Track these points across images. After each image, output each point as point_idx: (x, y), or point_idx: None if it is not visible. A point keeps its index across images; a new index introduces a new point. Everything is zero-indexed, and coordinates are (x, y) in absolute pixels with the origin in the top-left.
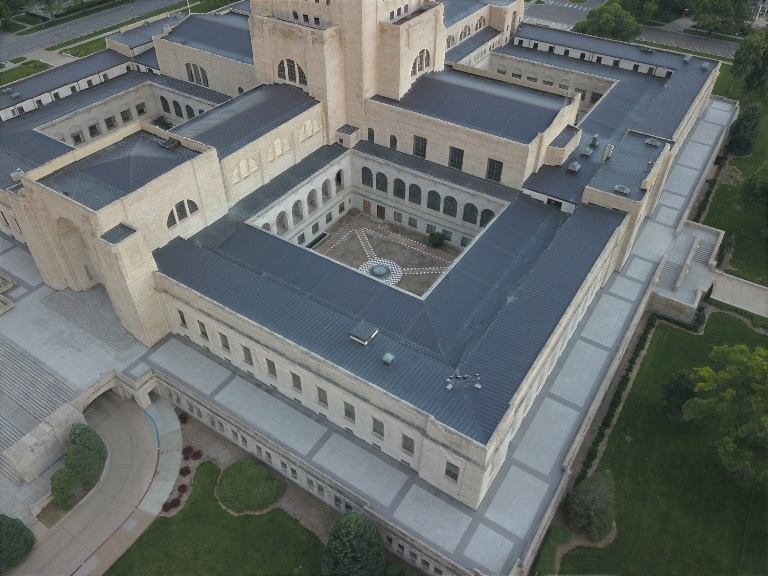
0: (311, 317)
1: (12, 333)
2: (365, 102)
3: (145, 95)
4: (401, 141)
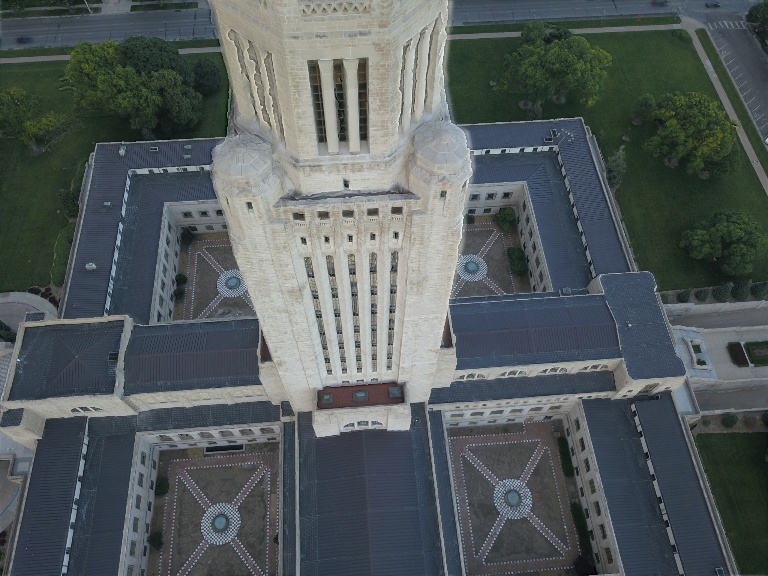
0: (45, 568)
1: None
2: (295, 413)
3: None
4: None
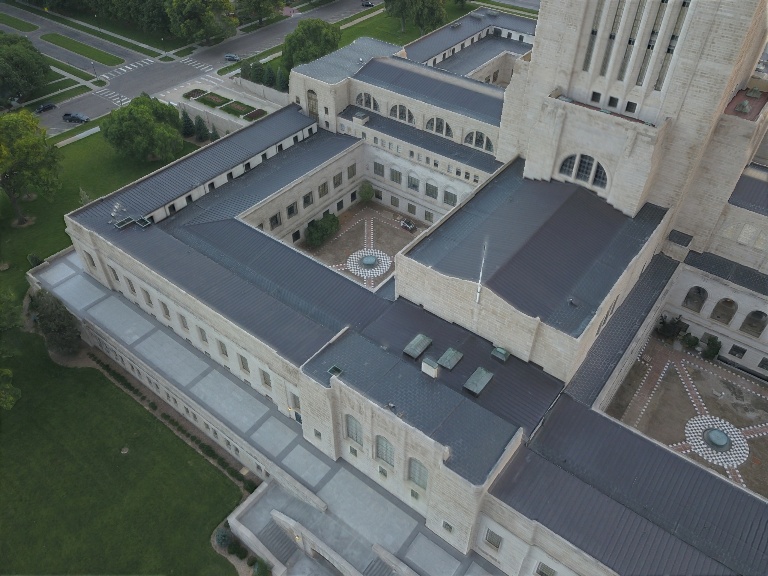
0: None
1: None
2: None
3: None
4: None
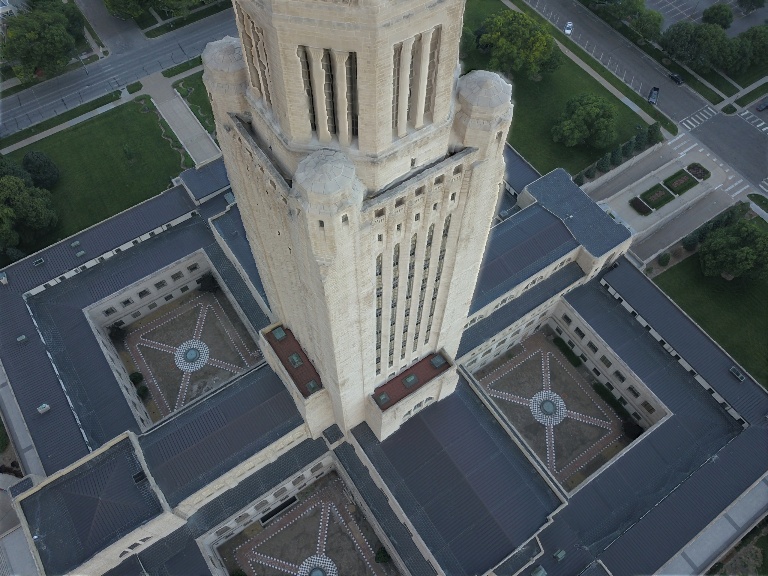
0: None
1: (14, 558)
2: (348, 432)
3: (198, 259)
4: (372, 476)
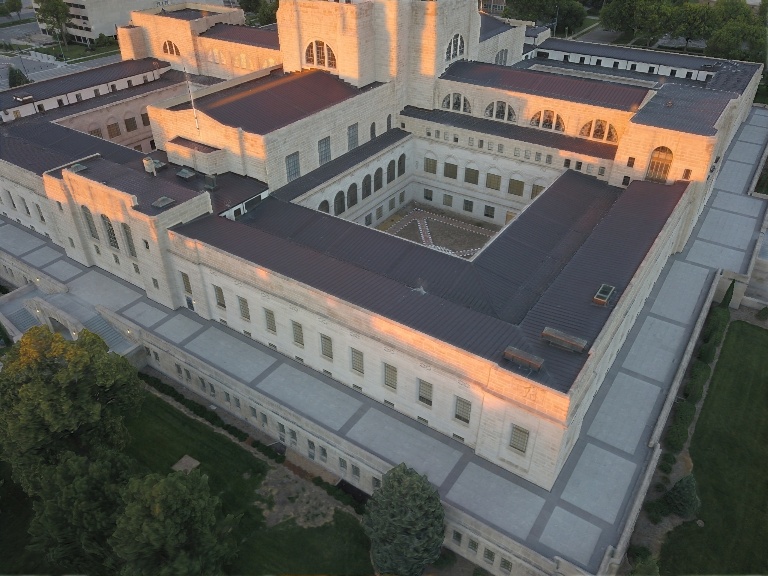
0: None
1: None
2: None
3: None
4: None
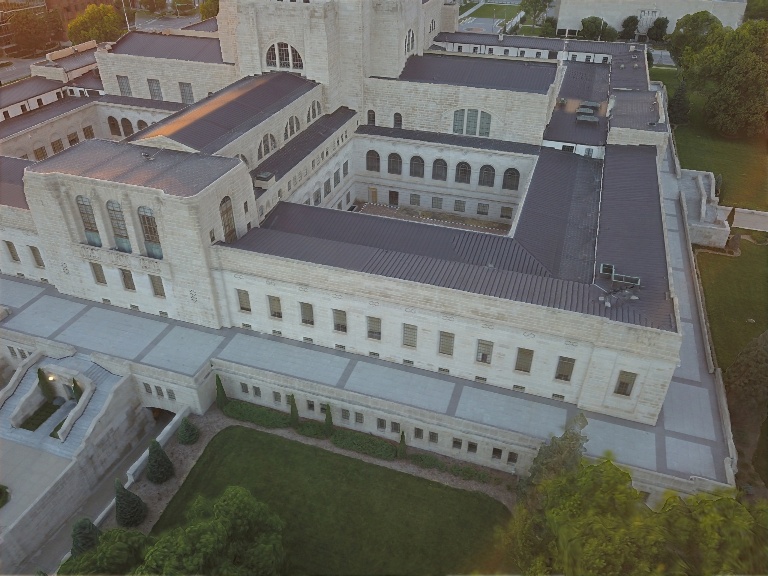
0: None
1: None
2: None
3: None
4: None
